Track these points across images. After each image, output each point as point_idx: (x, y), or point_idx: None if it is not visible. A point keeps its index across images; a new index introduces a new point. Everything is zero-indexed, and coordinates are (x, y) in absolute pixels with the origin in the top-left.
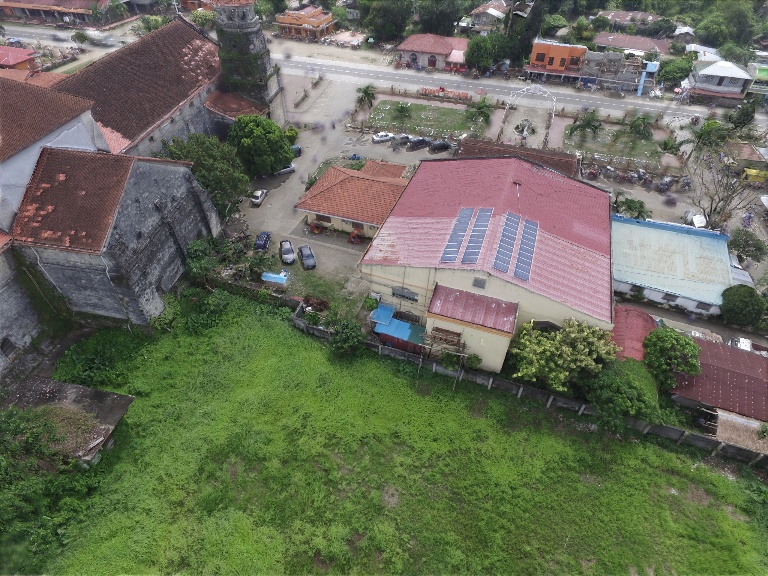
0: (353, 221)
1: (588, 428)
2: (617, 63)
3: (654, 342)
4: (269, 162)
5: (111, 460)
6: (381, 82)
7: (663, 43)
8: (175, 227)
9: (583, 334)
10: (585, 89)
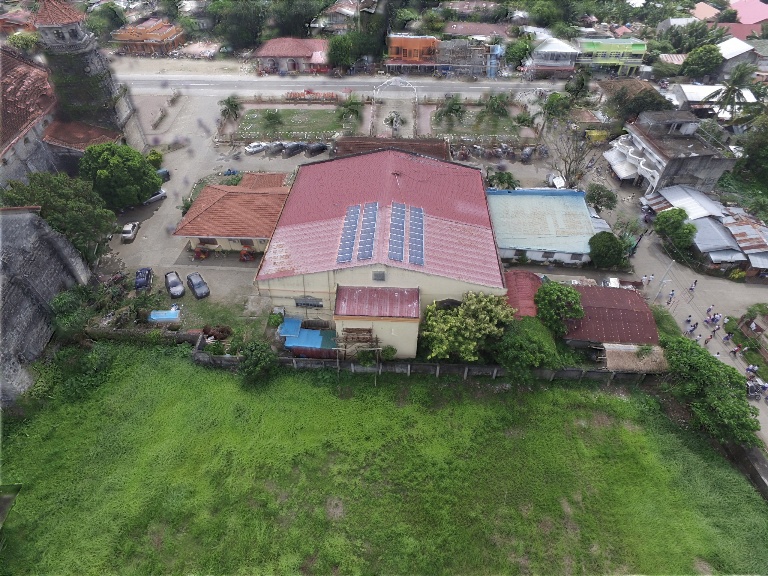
0: (241, 238)
1: (503, 389)
2: (464, 49)
3: (543, 297)
4: (134, 192)
5: (7, 563)
6: (243, 92)
7: (499, 27)
8: (33, 282)
9: (481, 304)
10: (441, 76)
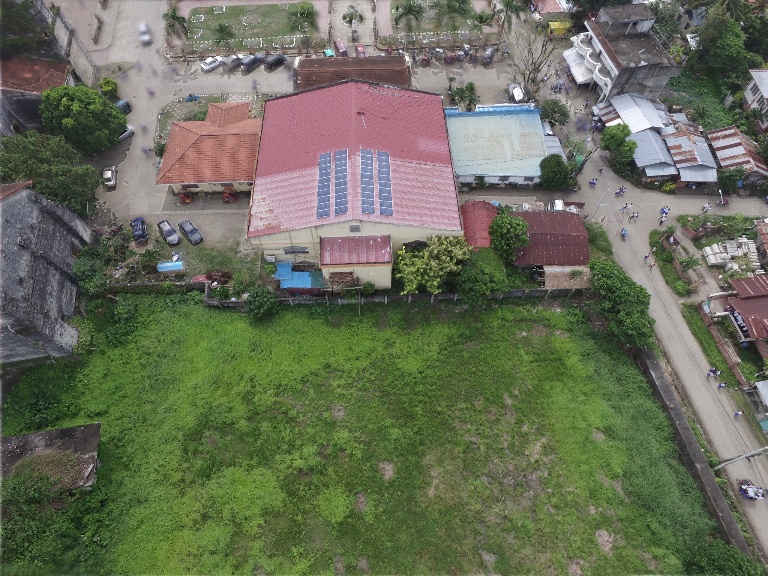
0: (221, 183)
1: (463, 308)
2: None
3: (495, 230)
4: (104, 137)
5: (105, 474)
6: None
7: None
8: (49, 256)
9: (443, 247)
10: None
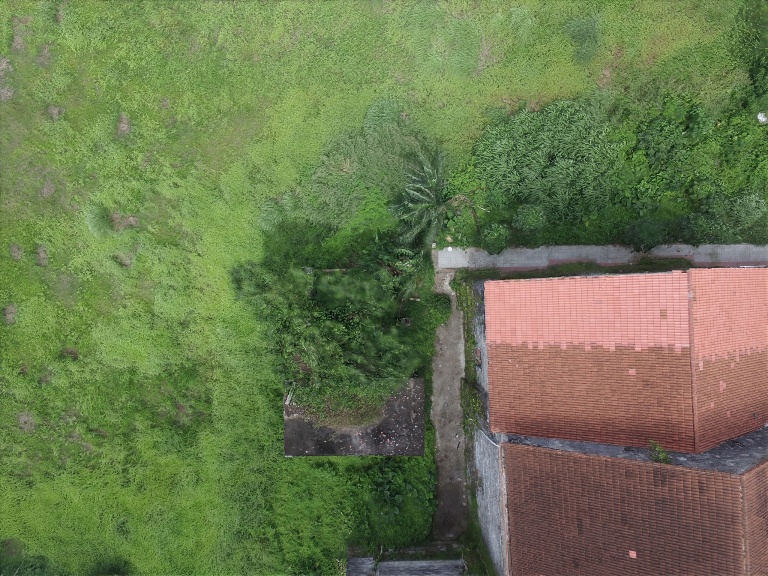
0: None
1: None
2: None
3: None
4: None
5: None
6: None
7: None
8: None
9: None
10: None
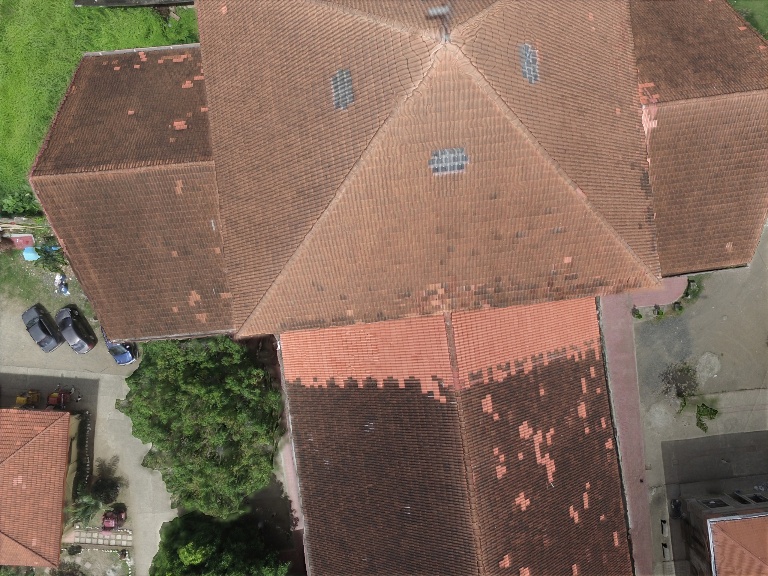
0: None
1: None
2: None
3: None
4: None
5: None
6: None
7: None
8: None
9: None
10: None
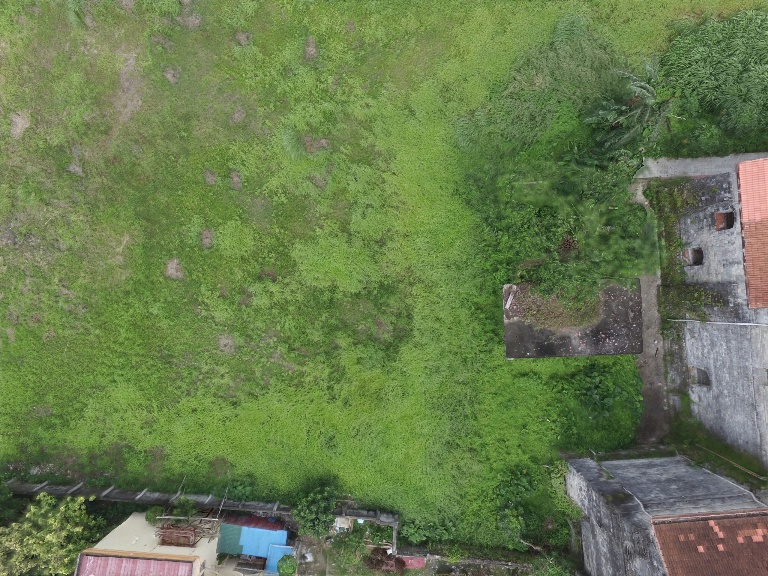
0: None
1: (41, 469)
2: None
3: None
4: None
5: None
6: None
7: None
8: None
9: None
10: None
